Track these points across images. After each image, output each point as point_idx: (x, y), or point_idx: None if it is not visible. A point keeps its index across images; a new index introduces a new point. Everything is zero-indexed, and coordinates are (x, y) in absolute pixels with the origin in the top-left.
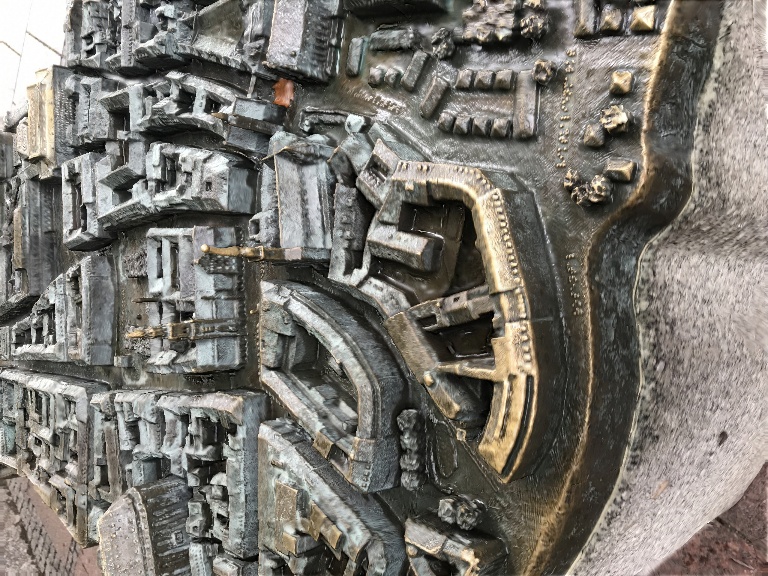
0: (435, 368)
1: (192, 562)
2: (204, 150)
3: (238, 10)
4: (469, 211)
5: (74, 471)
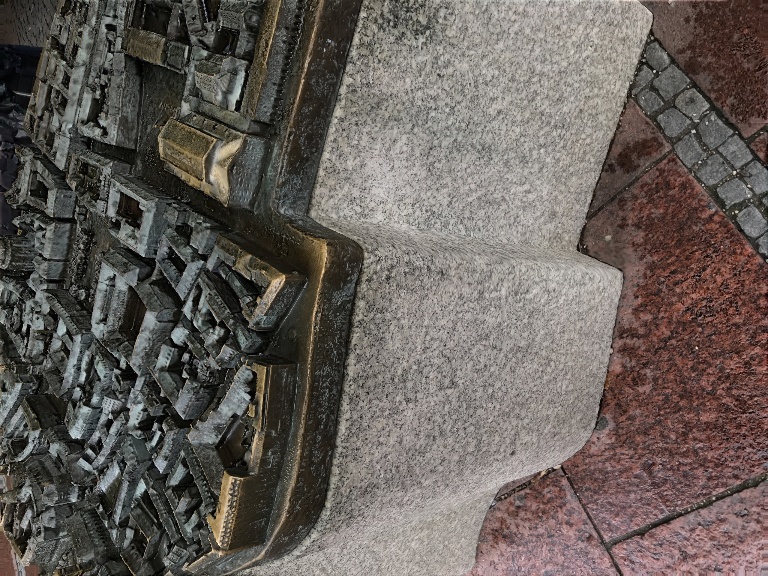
0: (6, 503)
1: (7, 286)
2: (85, 424)
3: (112, 510)
4: (22, 553)
5: (41, 132)
